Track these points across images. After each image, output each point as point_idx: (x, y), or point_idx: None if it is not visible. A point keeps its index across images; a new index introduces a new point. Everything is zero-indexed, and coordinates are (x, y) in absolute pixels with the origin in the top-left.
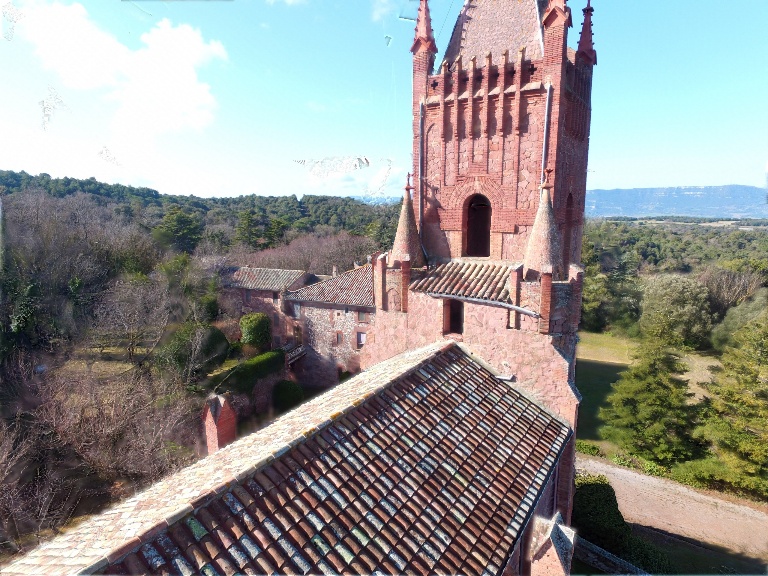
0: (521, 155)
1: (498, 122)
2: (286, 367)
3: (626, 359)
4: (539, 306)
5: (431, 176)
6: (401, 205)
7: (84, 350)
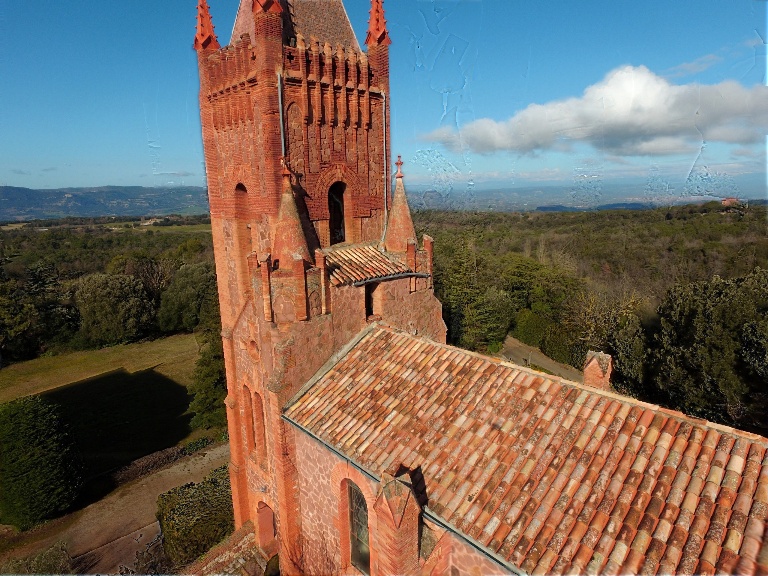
0: (369, 148)
1: (352, 115)
2: None
3: (99, 369)
4: (427, 268)
5: (294, 161)
6: None
7: None
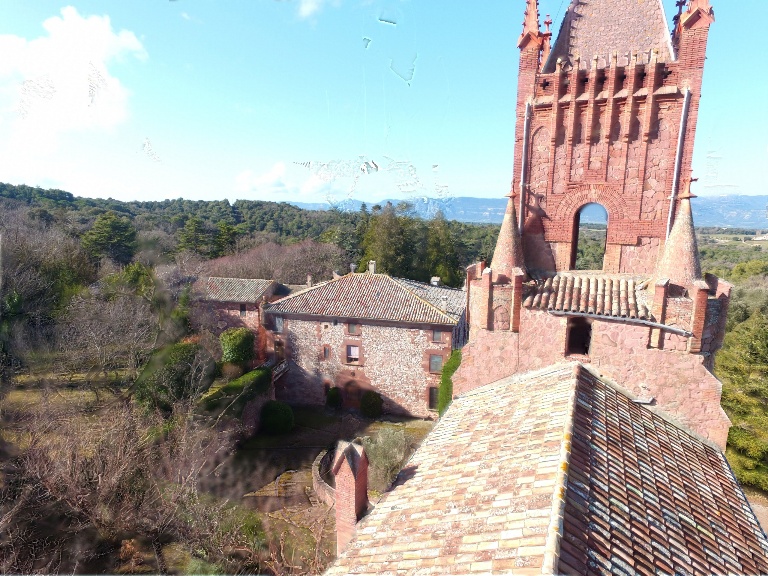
0: (648, 163)
1: (622, 127)
2: (272, 386)
3: None
4: (690, 324)
5: (535, 183)
6: (362, 212)
7: (40, 378)
